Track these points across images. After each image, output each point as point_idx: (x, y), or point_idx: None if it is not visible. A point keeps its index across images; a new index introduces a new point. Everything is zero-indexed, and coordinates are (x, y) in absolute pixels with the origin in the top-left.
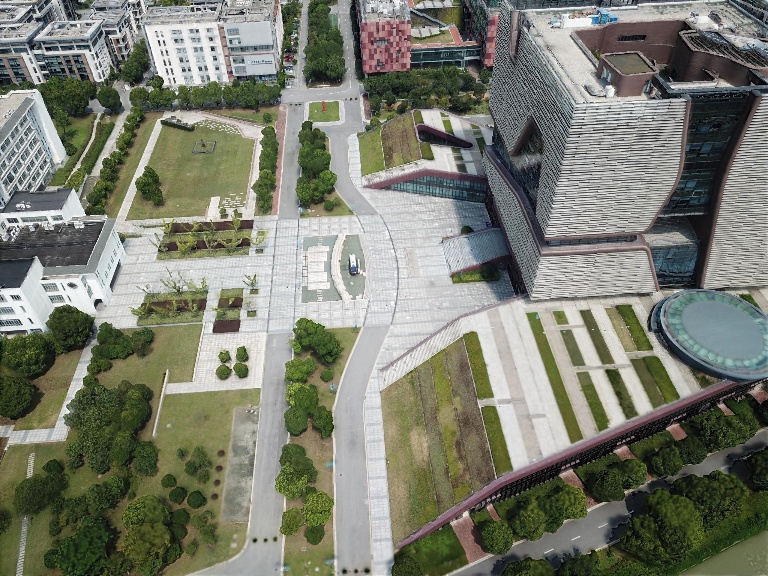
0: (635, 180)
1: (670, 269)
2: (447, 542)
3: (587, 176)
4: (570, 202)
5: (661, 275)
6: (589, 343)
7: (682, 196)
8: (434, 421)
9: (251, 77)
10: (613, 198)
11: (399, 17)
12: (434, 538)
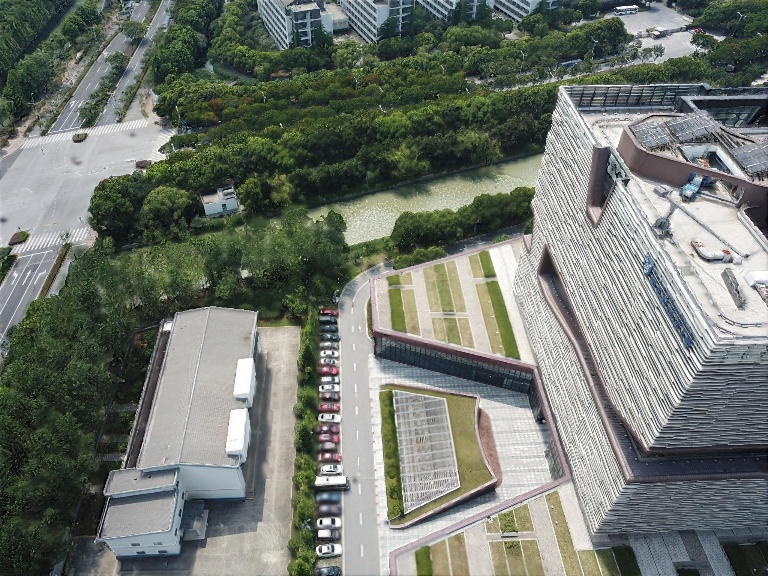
0: None
1: None
2: None
3: None
4: None
5: None
6: None
7: None
8: None
9: None
10: None
11: None
12: None
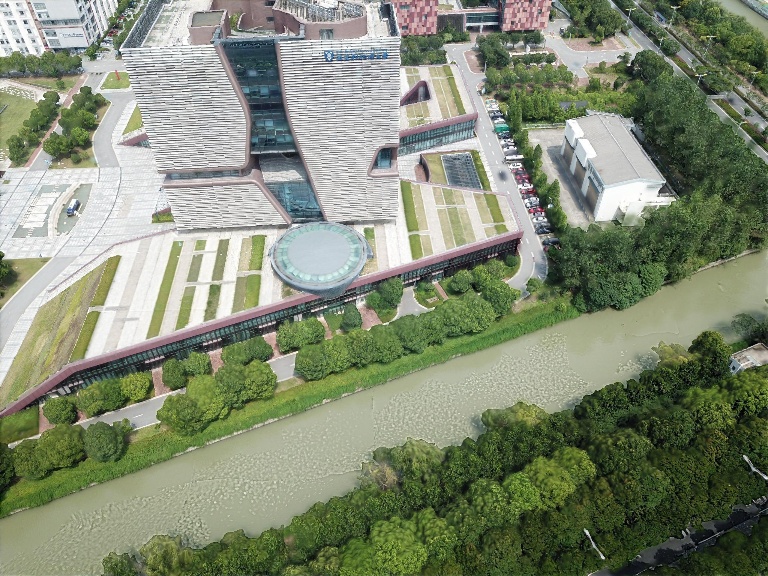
0: (210, 118)
1: (307, 205)
2: (27, 418)
3: (165, 114)
4: (162, 138)
5: (294, 210)
6: (211, 265)
7: (267, 134)
8: (57, 326)
9: (63, 49)
10: (200, 134)
11: None
12: (18, 415)
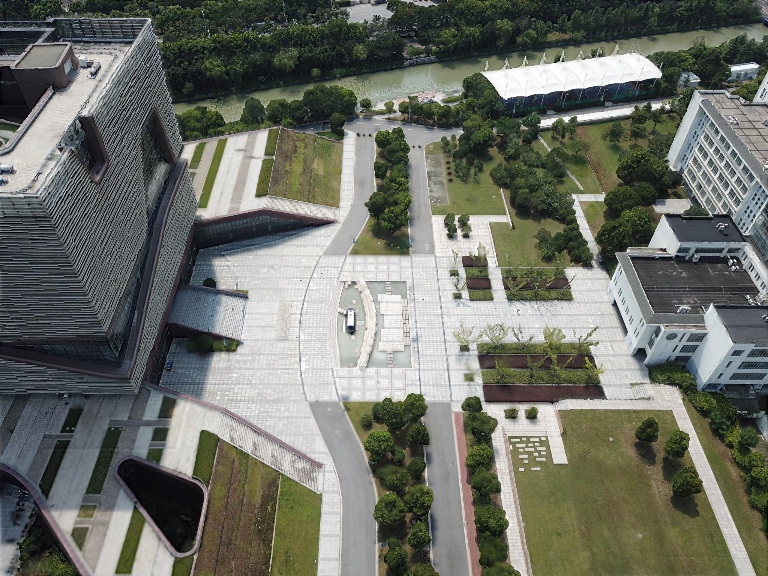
0: None
1: None
2: None
3: None
4: None
5: None
6: None
7: None
8: (306, 169)
9: None
10: None
11: None
12: None
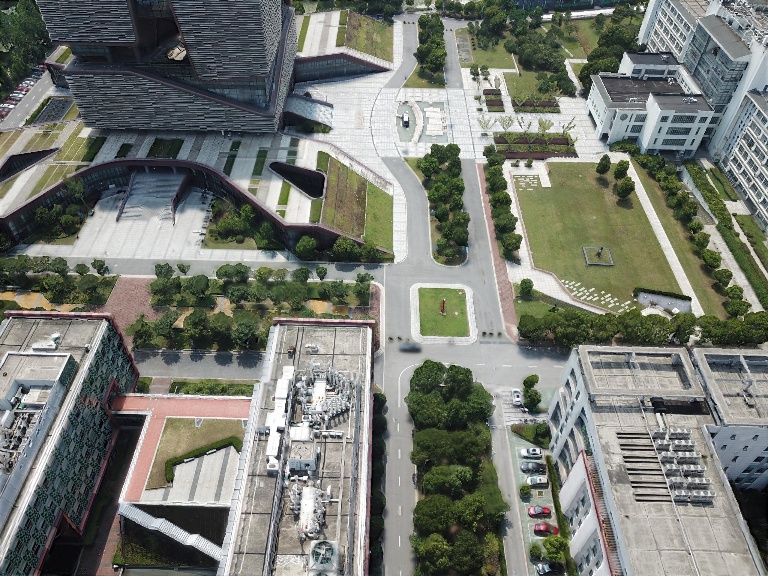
0: None
1: None
2: None
3: None
4: None
5: None
6: None
7: None
8: None
9: None
10: None
11: (291, 347)
12: None
